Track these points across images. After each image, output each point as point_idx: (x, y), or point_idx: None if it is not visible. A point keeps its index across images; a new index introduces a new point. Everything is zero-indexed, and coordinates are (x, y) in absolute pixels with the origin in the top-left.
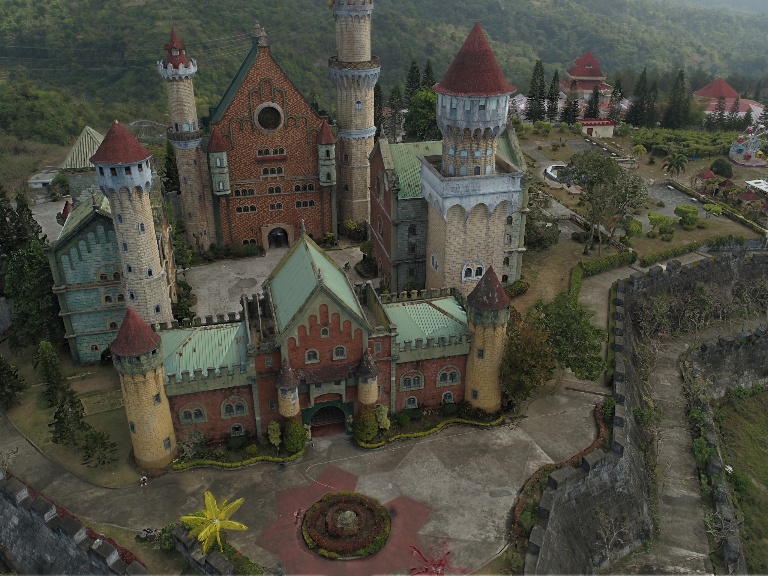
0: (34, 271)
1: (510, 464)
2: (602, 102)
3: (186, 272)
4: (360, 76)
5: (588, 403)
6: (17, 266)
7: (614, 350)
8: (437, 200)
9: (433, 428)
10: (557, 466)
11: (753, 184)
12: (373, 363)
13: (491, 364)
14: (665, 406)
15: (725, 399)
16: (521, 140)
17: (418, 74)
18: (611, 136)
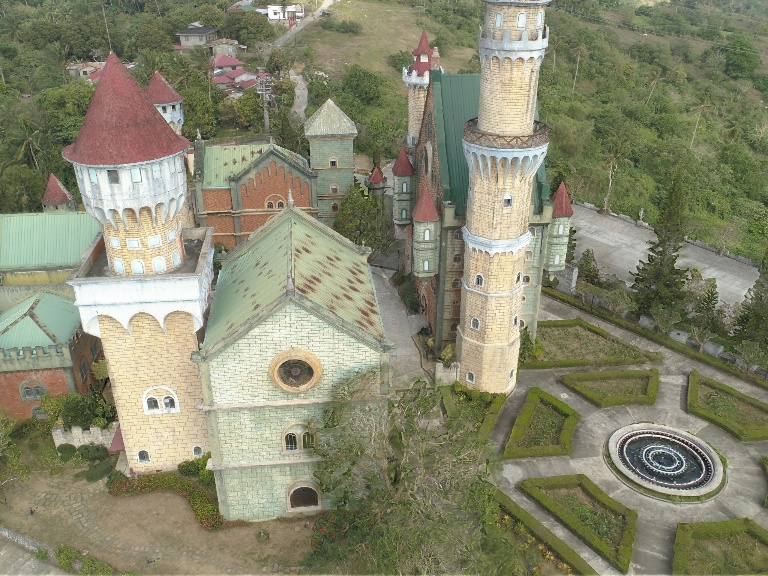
0: None
1: None
2: None
3: (377, 276)
4: None
5: None
6: None
7: None
8: None
9: None
10: None
11: None
12: None
13: None
14: None
15: None
16: None
17: None
18: None
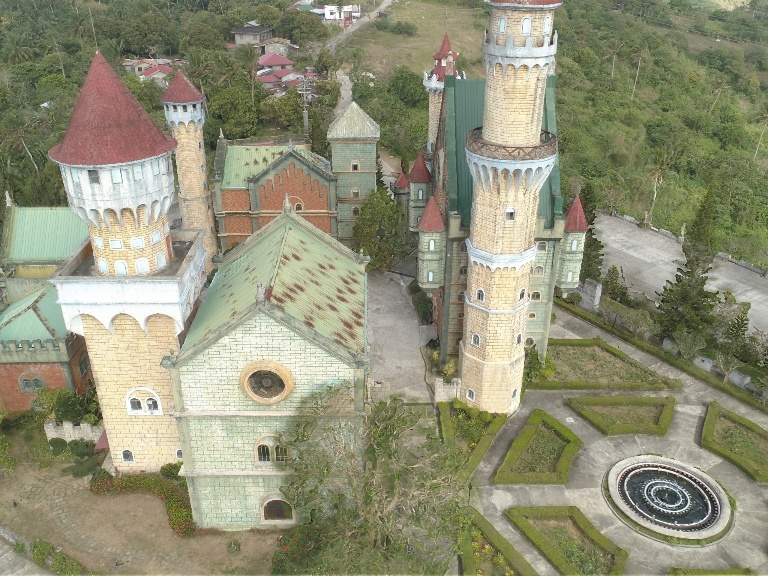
0: None
1: None
2: None
3: (395, 283)
4: None
5: None
6: None
7: None
8: None
9: None
10: None
11: None
12: None
13: None
14: None
15: None
16: None
17: None
18: None
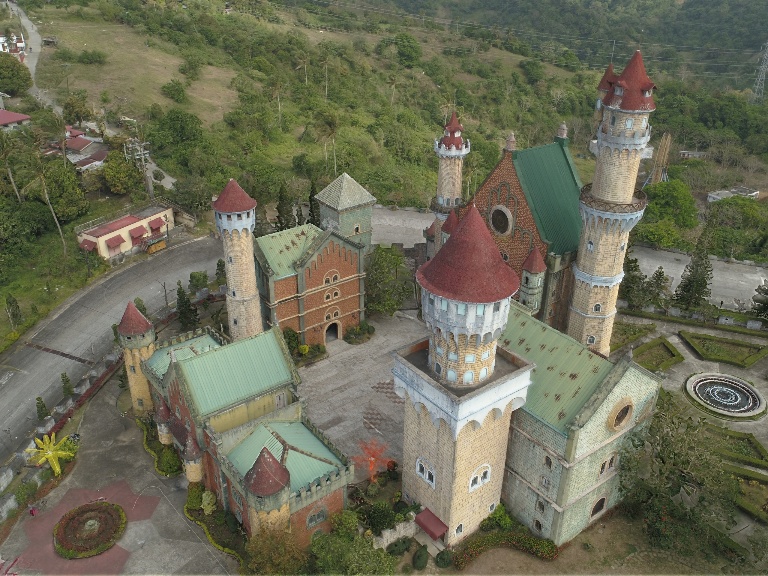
0: None
1: None
2: None
3: (406, 319)
4: None
5: None
6: None
7: None
8: None
9: (221, 545)
10: None
11: None
12: (190, 449)
13: None
14: None
15: None
16: None
17: None
18: None
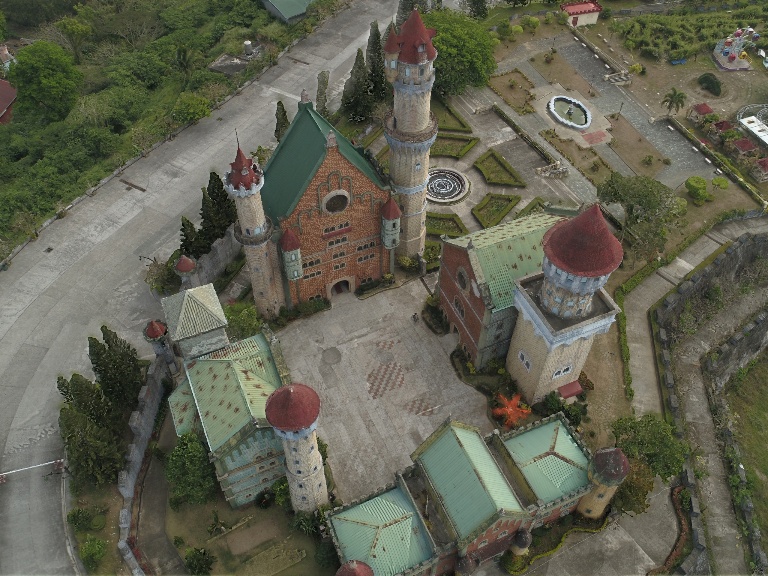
0: (195, 466)
1: (624, 572)
2: None
3: None
4: (422, 145)
5: (664, 486)
6: None
7: (670, 410)
8: None
9: (559, 544)
10: (660, 572)
11: (747, 125)
12: (529, 536)
13: (607, 499)
14: (698, 429)
15: (730, 384)
16: (510, 44)
17: (413, 2)
18: (595, 22)
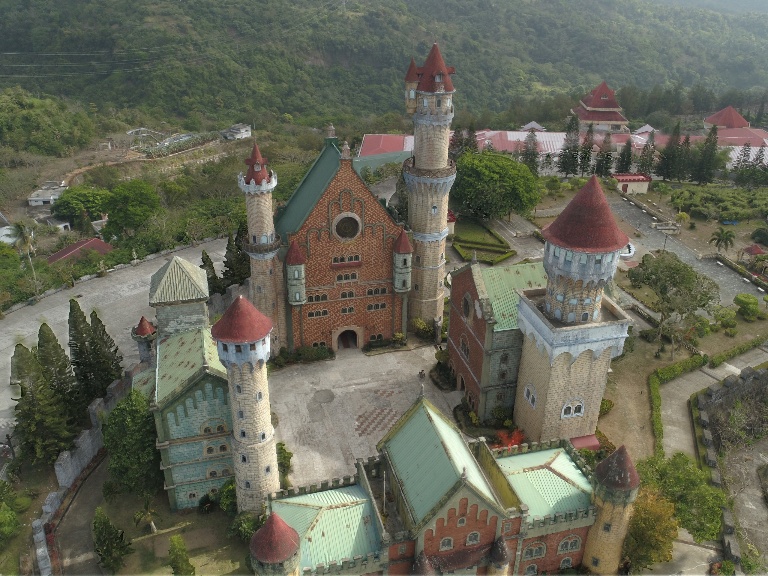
0: (136, 425)
1: None
2: (634, 154)
3: None
4: (438, 183)
5: (701, 561)
6: (118, 420)
7: (711, 487)
8: (543, 344)
9: None
10: None
11: None
12: (507, 548)
13: (616, 537)
14: (756, 536)
15: None
16: (558, 198)
17: (462, 138)
18: (645, 192)
